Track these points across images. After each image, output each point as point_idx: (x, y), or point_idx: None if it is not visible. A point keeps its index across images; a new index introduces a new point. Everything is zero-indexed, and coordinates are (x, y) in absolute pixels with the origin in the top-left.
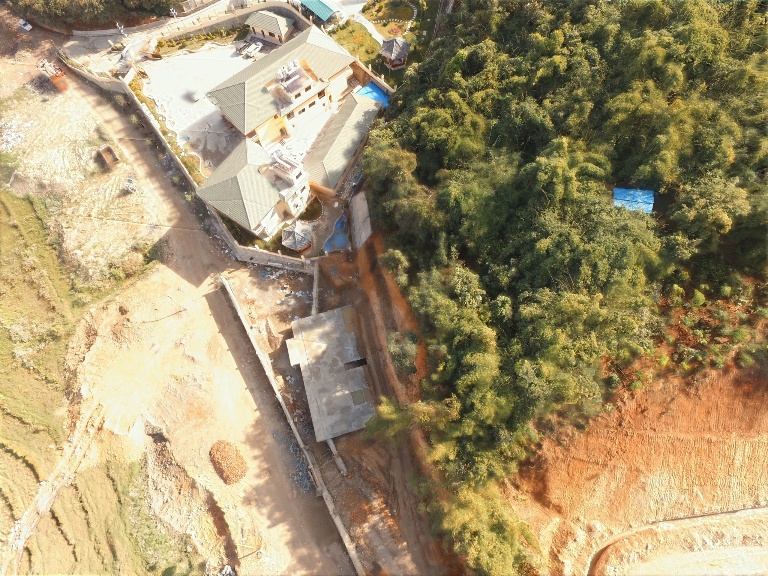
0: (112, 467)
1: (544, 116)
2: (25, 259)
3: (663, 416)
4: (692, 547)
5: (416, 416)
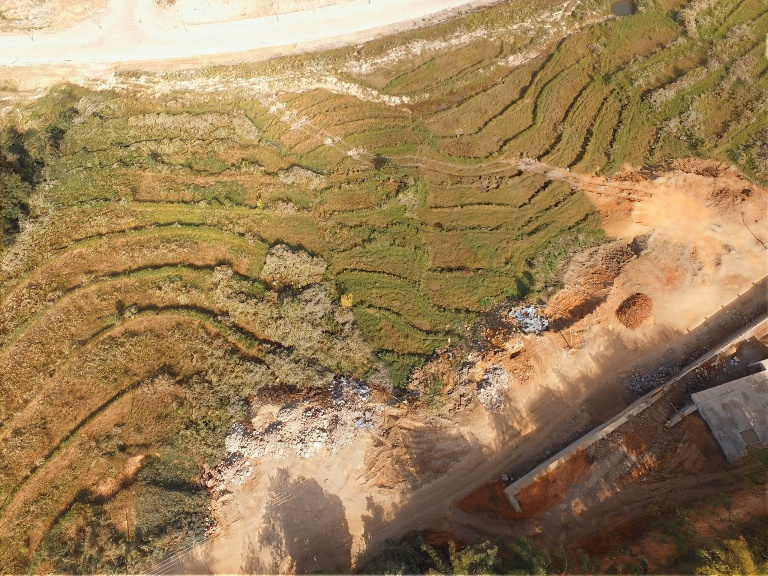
0: (596, 216)
1: None
2: (760, 102)
3: None
4: None
5: None
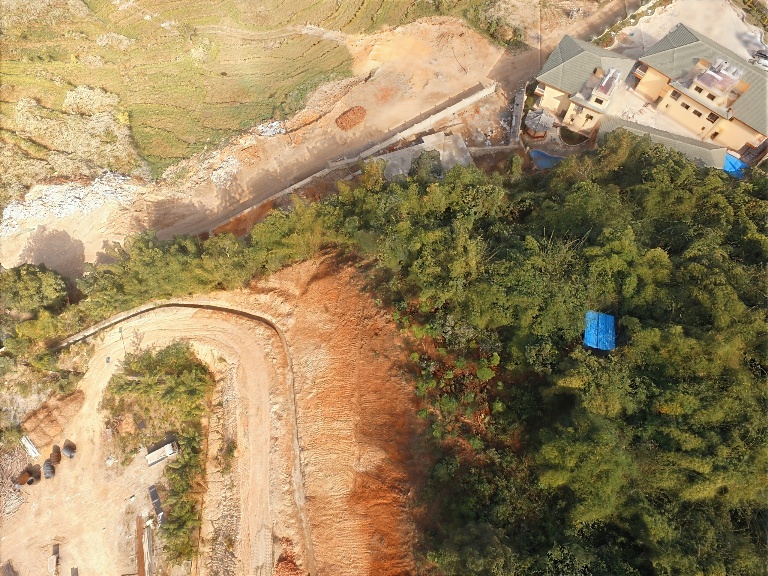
0: (349, 61)
1: (700, 250)
2: None
3: (373, 353)
4: (272, 393)
5: (369, 163)
